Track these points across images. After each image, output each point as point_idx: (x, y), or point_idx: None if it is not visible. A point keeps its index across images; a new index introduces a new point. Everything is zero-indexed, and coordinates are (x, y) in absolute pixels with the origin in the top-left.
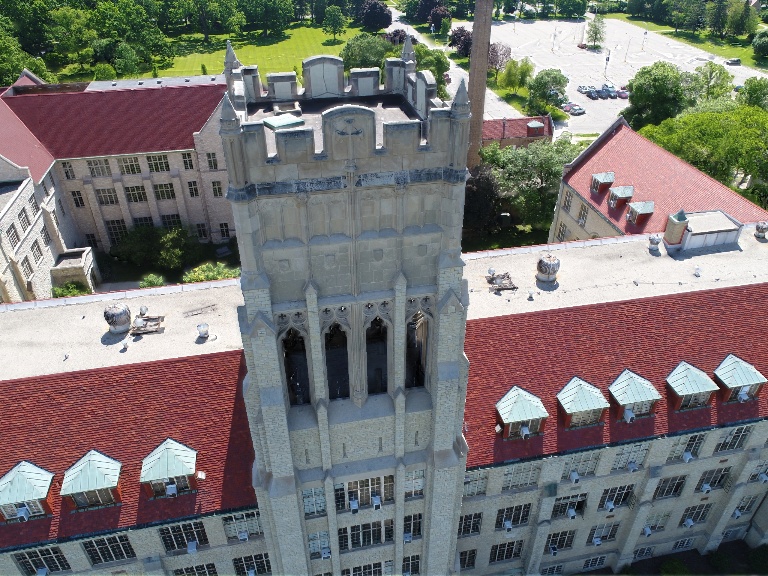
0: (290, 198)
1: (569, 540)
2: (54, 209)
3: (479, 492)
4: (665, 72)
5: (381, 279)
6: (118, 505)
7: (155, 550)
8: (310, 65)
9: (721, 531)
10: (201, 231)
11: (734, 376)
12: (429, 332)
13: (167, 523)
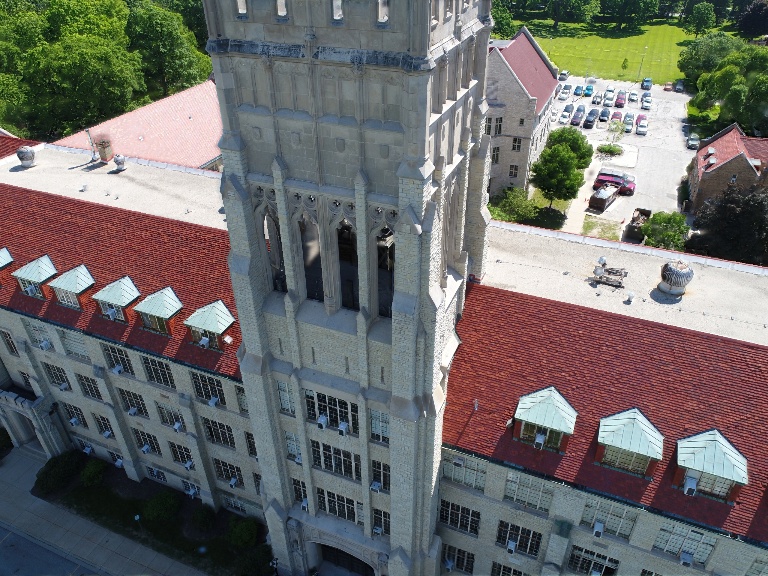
0: (258, 61)
1: None
2: None
3: (478, 486)
4: None
5: (345, 175)
6: (169, 337)
7: (188, 390)
8: None
9: None
10: None
11: None
12: None
13: (193, 368)
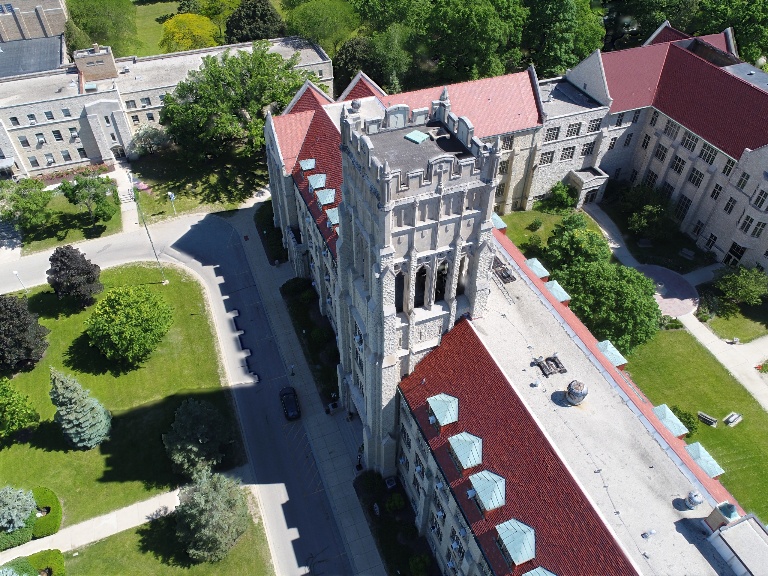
0: None
1: None
2: (617, 137)
3: None
4: None
5: None
6: None
7: None
8: (460, 120)
9: None
10: (698, 228)
11: None
12: None
13: None
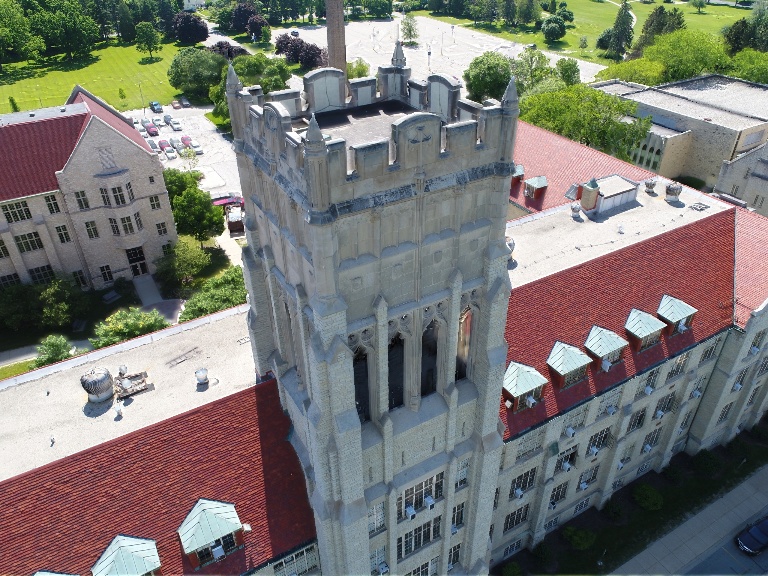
0: (366, 214)
1: (563, 492)
2: None
3: None
4: (496, 61)
5: (439, 280)
6: None
7: None
8: (313, 79)
9: (671, 448)
10: (79, 279)
11: (674, 312)
12: (474, 323)
13: None
